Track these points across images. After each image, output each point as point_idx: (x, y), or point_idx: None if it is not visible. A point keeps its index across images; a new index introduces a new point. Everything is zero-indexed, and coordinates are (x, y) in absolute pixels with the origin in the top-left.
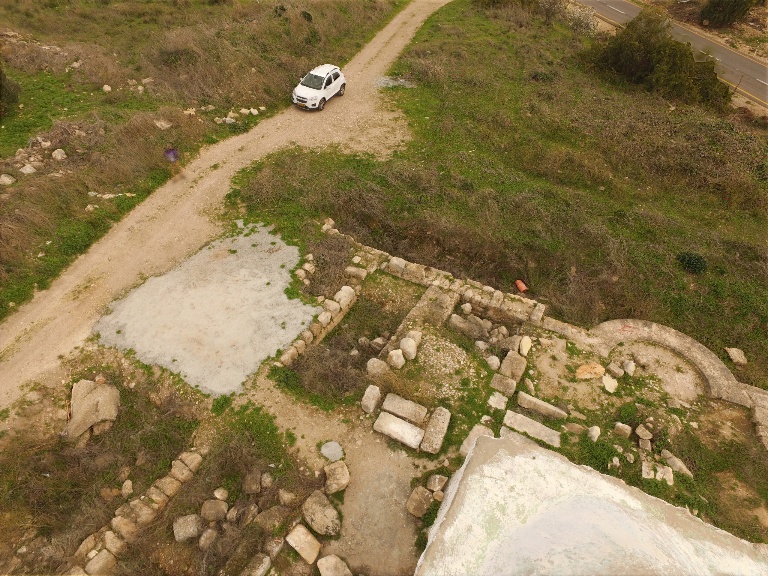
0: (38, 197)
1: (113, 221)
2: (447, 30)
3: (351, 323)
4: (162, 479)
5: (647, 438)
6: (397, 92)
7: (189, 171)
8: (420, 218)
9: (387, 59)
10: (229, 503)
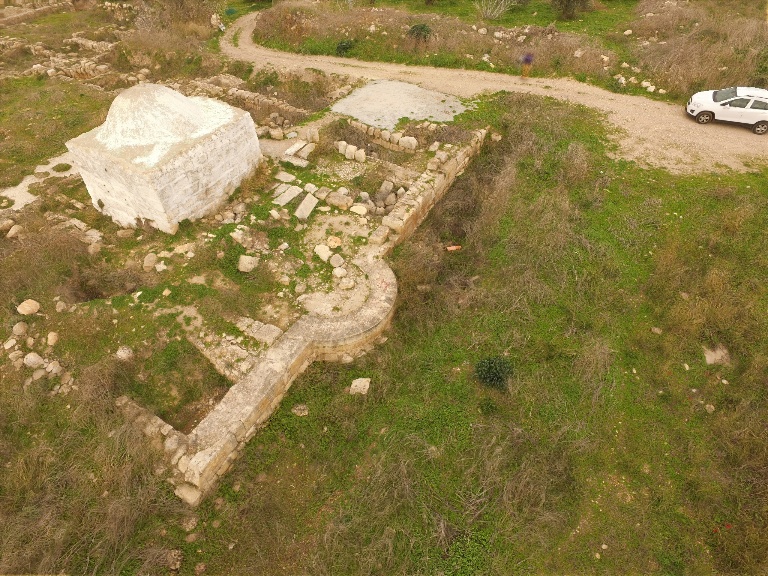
0: (469, 41)
1: (465, 67)
2: None
3: None
4: None
5: None
6: None
7: (536, 80)
8: None
9: None
10: None
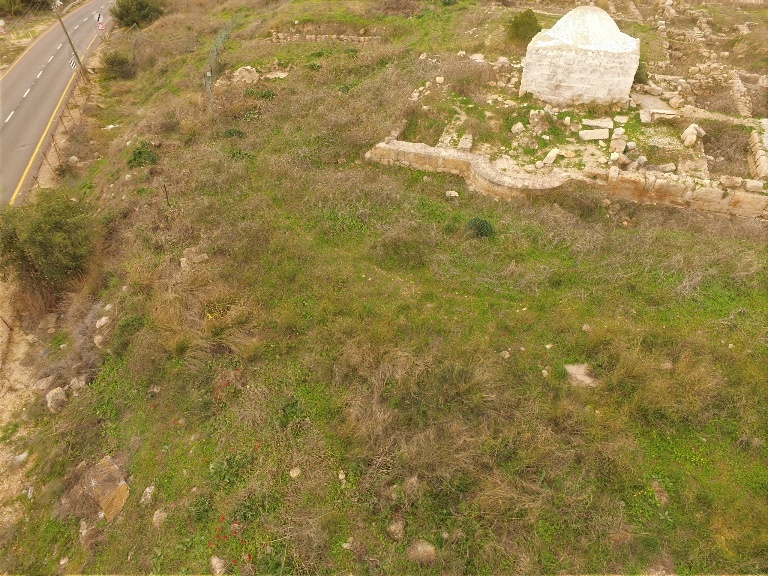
0: None
1: None
2: None
3: None
4: None
5: None
6: None
7: None
8: None
9: None
10: None
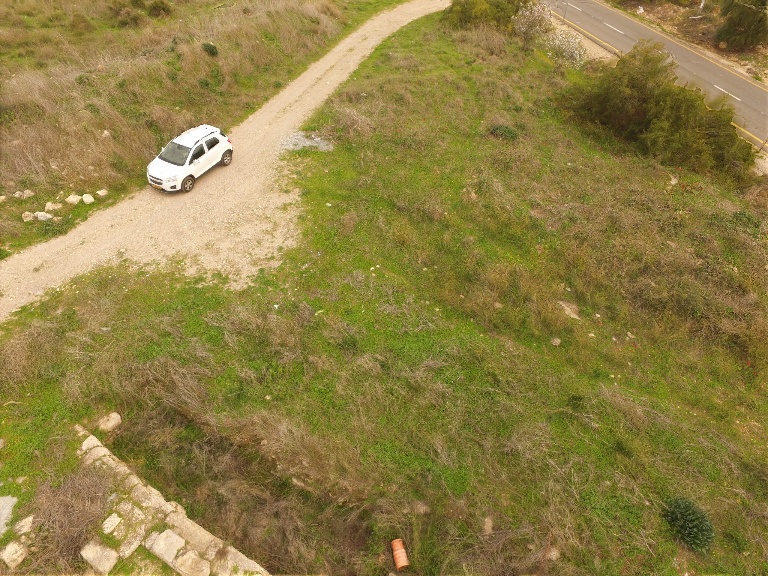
0: None
1: None
2: (398, 60)
3: None
4: None
5: None
6: (304, 158)
7: None
8: None
9: (309, 104)
10: None
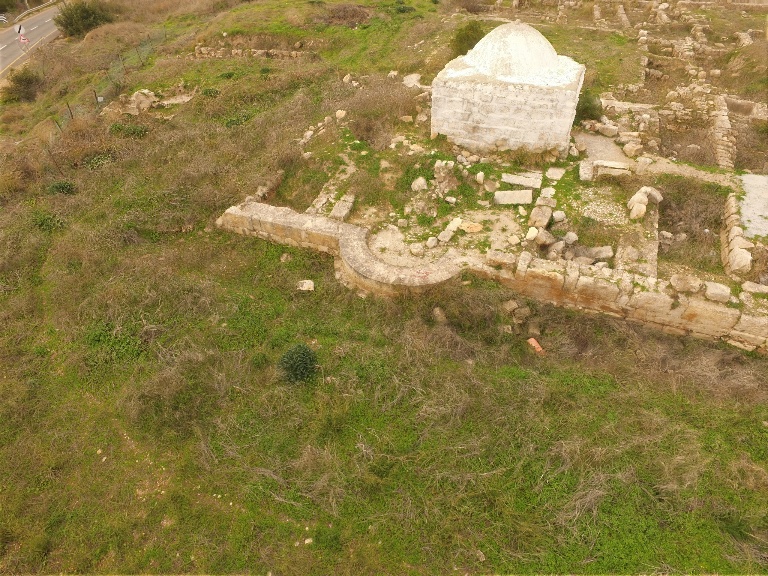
0: None
1: None
2: None
3: None
4: None
5: None
6: None
7: None
8: (760, 401)
9: None
10: None
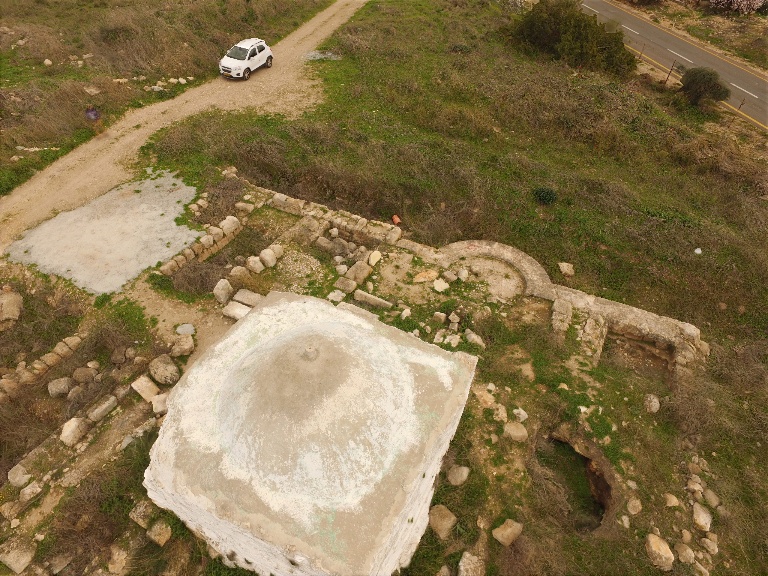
0: None
1: (36, 170)
2: (384, 10)
3: (234, 247)
4: (45, 354)
5: (456, 321)
6: (322, 64)
7: (113, 130)
8: None
9: (321, 36)
10: (99, 371)
